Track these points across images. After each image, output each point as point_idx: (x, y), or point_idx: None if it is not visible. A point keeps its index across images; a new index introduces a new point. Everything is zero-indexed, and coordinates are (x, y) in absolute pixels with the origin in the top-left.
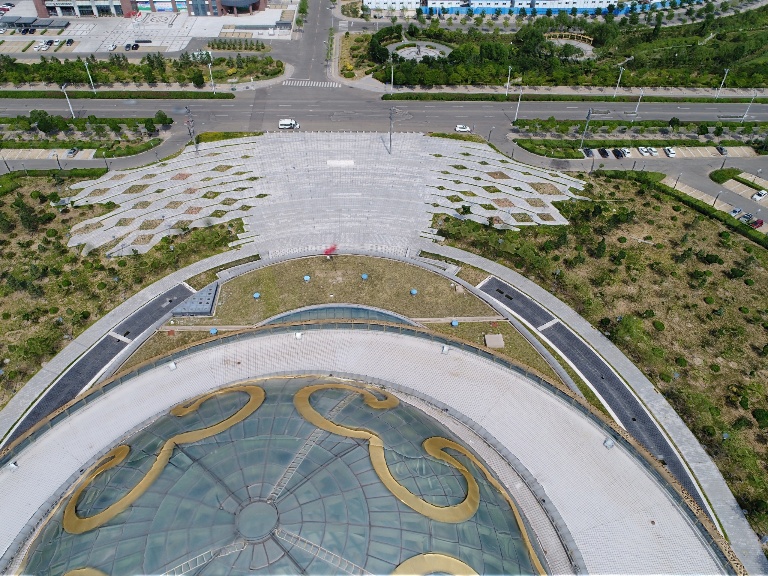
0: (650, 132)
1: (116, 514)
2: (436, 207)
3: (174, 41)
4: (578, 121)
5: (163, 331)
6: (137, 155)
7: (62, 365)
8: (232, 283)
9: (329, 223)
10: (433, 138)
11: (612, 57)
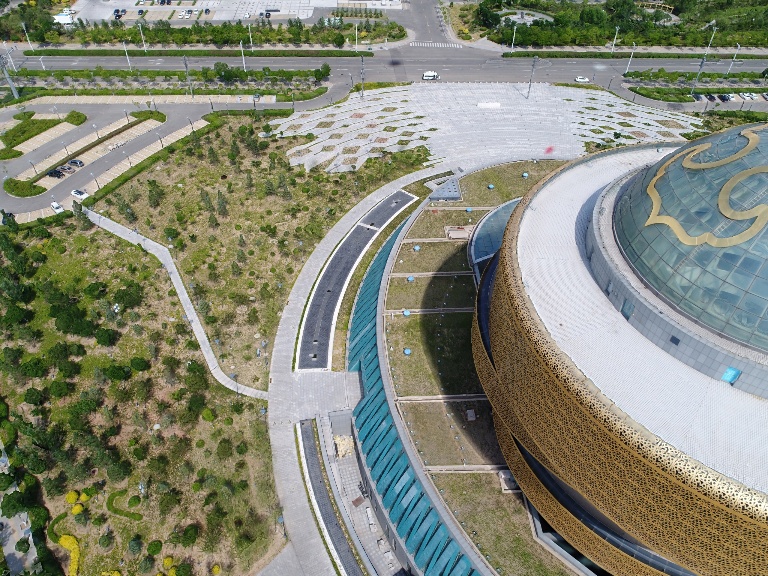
0: (744, 82)
1: (750, 150)
2: (584, 137)
3: (299, 10)
4: (681, 73)
5: (428, 210)
6: (311, 100)
7: (331, 245)
8: (466, 179)
9: (500, 149)
10: (559, 87)
11: (694, 23)
